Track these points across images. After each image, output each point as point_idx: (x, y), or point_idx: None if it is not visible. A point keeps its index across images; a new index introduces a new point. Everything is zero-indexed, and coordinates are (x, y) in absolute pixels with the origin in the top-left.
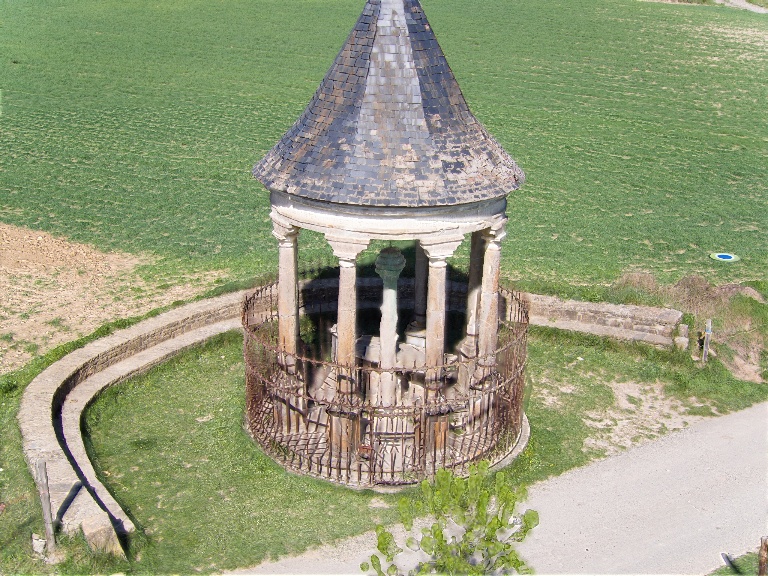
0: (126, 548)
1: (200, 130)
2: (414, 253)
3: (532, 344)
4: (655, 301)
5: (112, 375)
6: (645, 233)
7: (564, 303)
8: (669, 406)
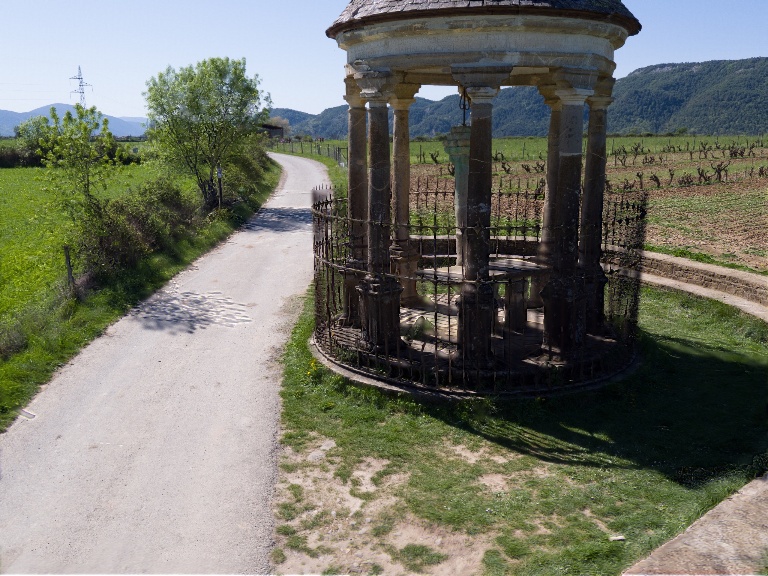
0: None
1: None
2: None
3: None
4: None
5: None
6: None
7: None
8: None
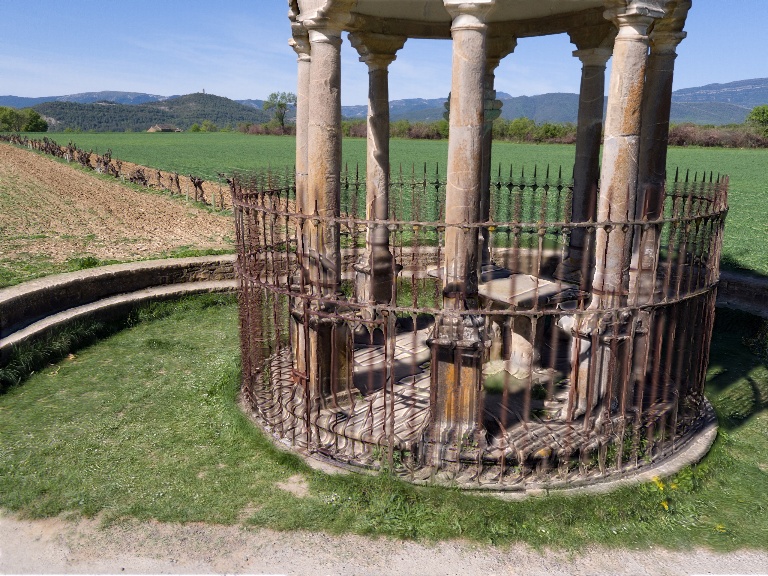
0: None
1: None
2: None
3: None
4: None
5: (223, 284)
6: None
7: None
8: None
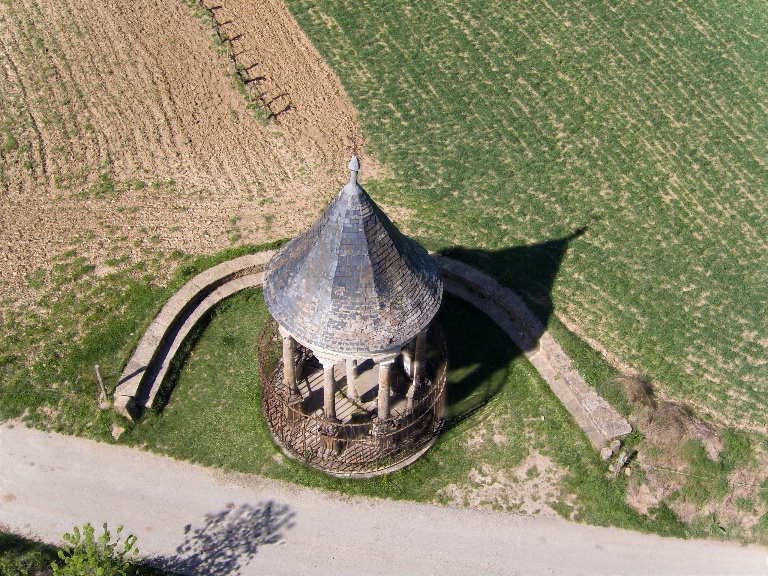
0: (139, 415)
1: (606, 1)
2: (547, 258)
3: (530, 386)
4: (623, 410)
5: (257, 280)
6: (767, 323)
7: (568, 372)
8: (548, 492)
